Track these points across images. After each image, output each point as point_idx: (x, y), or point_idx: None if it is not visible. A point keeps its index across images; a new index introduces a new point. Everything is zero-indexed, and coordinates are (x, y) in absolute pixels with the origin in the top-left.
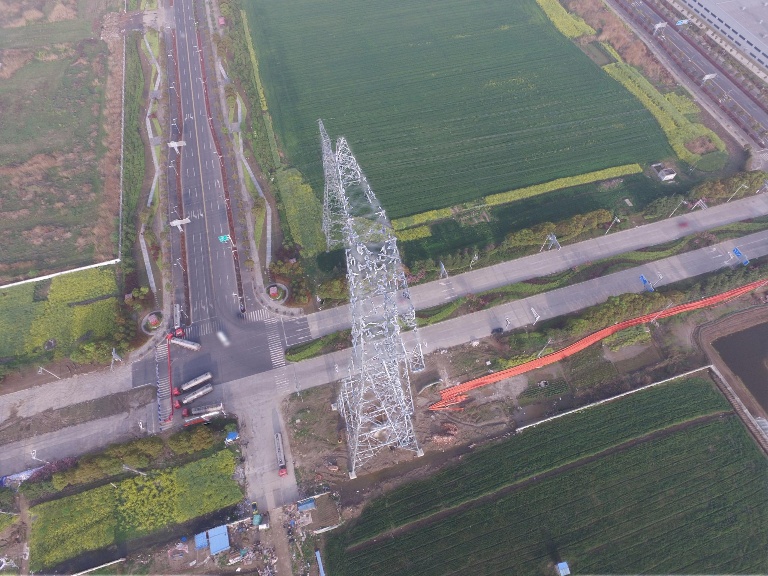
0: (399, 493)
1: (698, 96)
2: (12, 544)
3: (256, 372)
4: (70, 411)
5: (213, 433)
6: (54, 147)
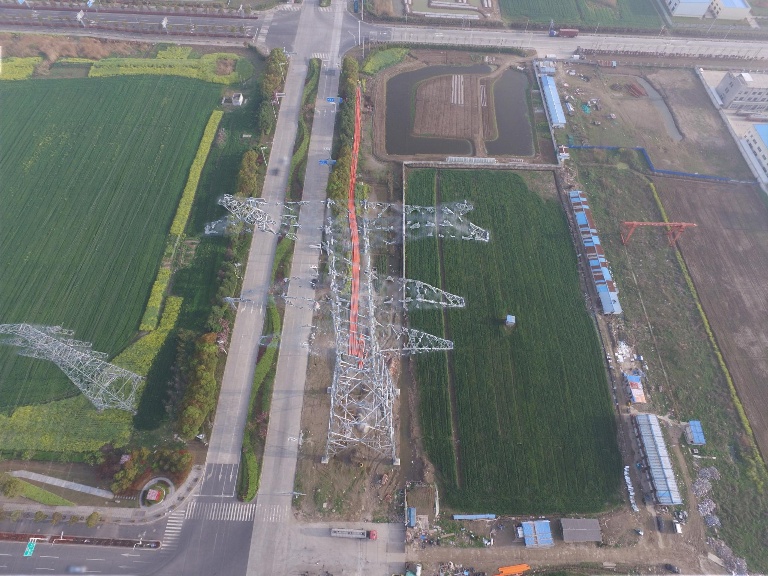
0: (425, 423)
1: (176, 41)
2: None
3: (248, 544)
4: None
5: None
6: None
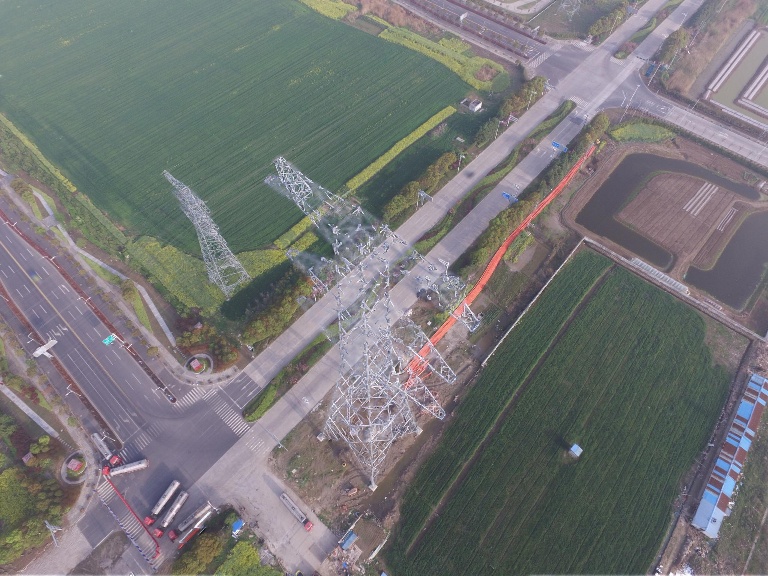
0: (421, 476)
1: (463, 35)
2: None
3: (224, 451)
4: None
5: (216, 535)
6: None
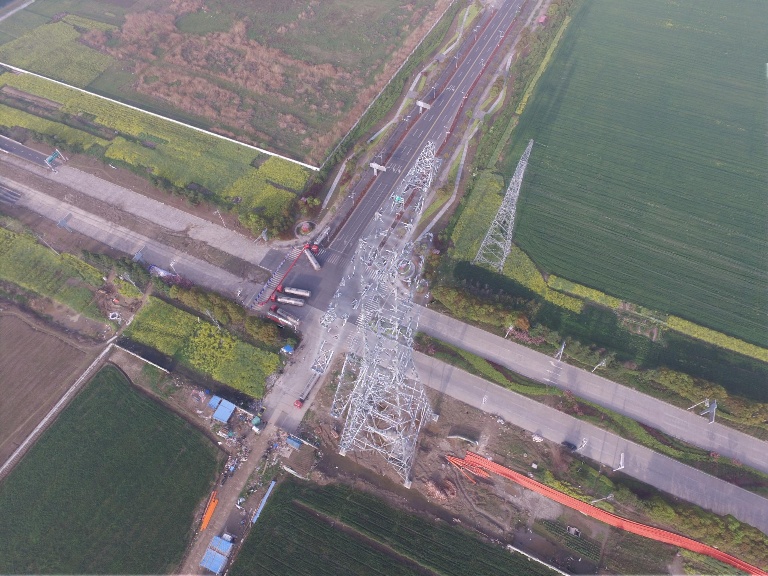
0: (365, 498)
1: None
2: (128, 309)
3: None
4: (214, 252)
5: (278, 336)
6: (342, 63)
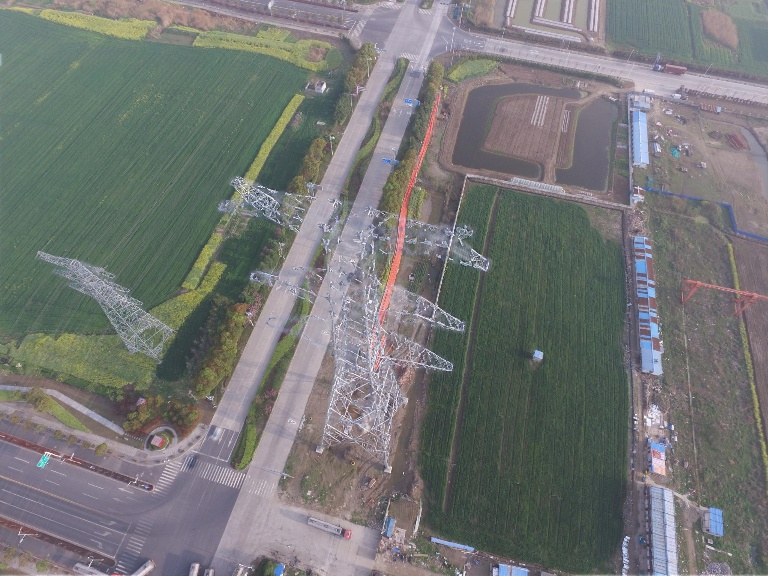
0: (425, 438)
1: (277, 23)
2: None
3: (230, 510)
4: None
5: None
6: None
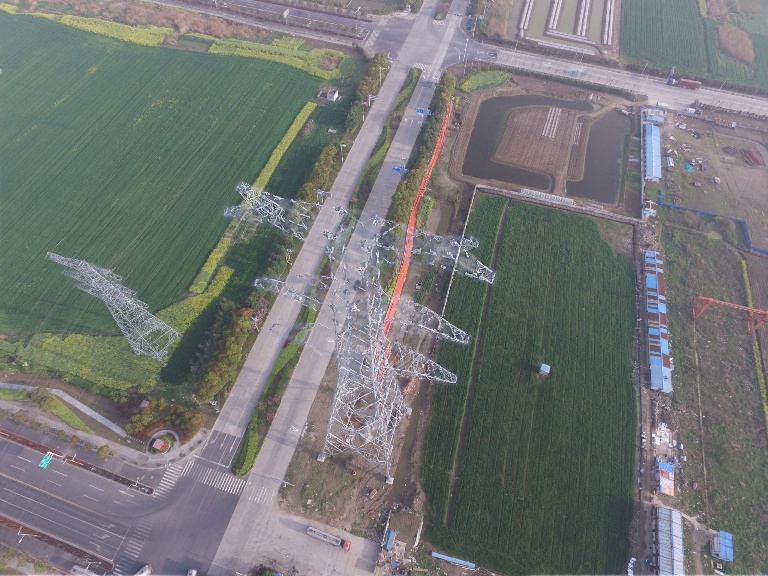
0: (428, 450)
1: (292, 31)
2: None
3: (229, 517)
4: None
5: None
6: None
